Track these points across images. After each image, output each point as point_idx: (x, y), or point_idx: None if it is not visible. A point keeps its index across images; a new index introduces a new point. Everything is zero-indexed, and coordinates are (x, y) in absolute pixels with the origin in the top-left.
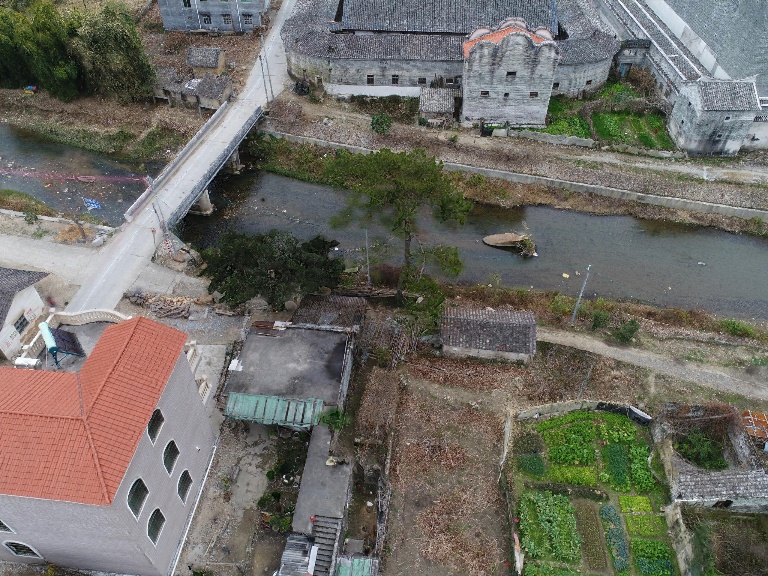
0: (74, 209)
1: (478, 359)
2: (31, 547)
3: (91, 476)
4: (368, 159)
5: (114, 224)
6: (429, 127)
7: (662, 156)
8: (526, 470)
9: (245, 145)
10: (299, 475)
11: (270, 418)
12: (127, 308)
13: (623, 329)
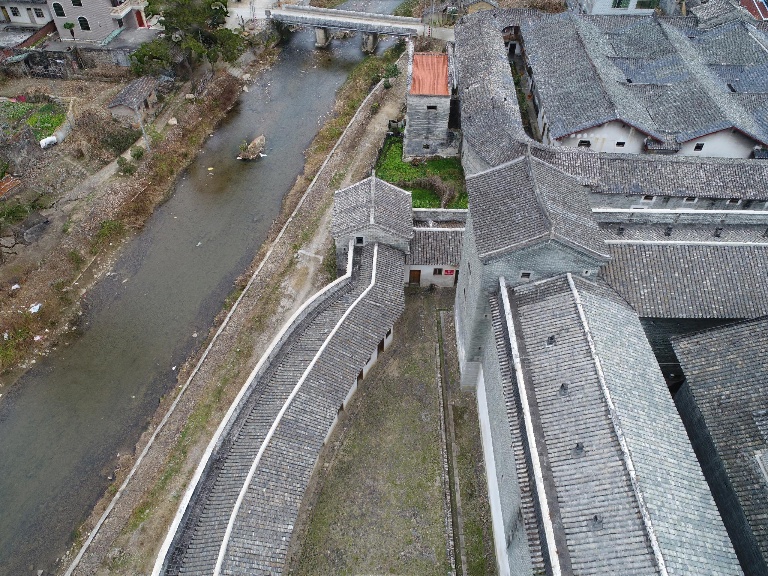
0: None
1: None
2: None
3: None
4: None
5: None
6: None
7: None
8: (44, 106)
9: (395, 47)
10: None
11: None
12: None
13: None
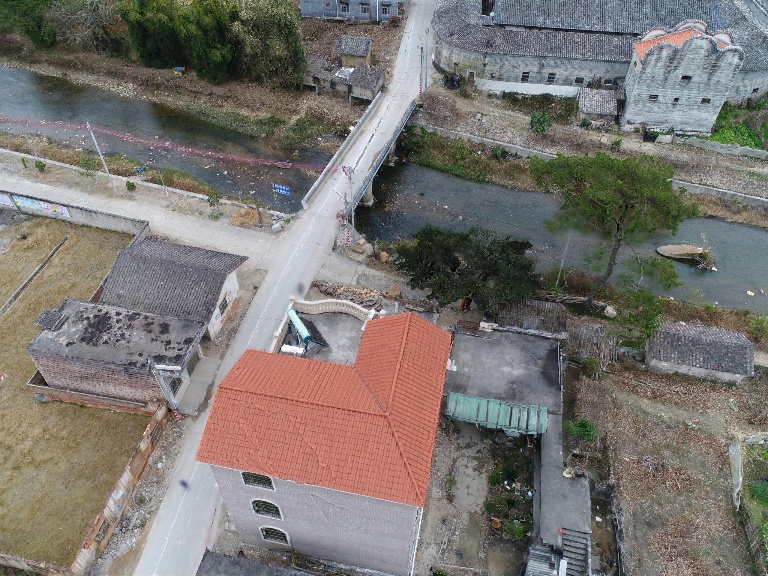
0: (236, 192)
1: (686, 376)
2: (287, 534)
3: (402, 475)
4: (590, 162)
5: (278, 210)
6: (587, 129)
7: None
8: (761, 499)
9: None
10: (519, 482)
11: (493, 422)
12: (317, 297)
13: None
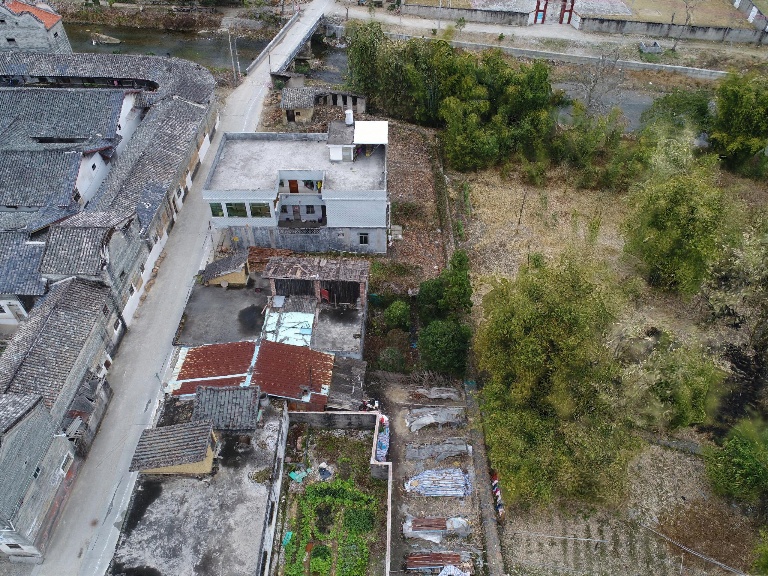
0: None
1: None
2: None
3: None
4: None
5: None
6: None
7: None
8: None
9: None
10: None
11: None
12: None
13: None
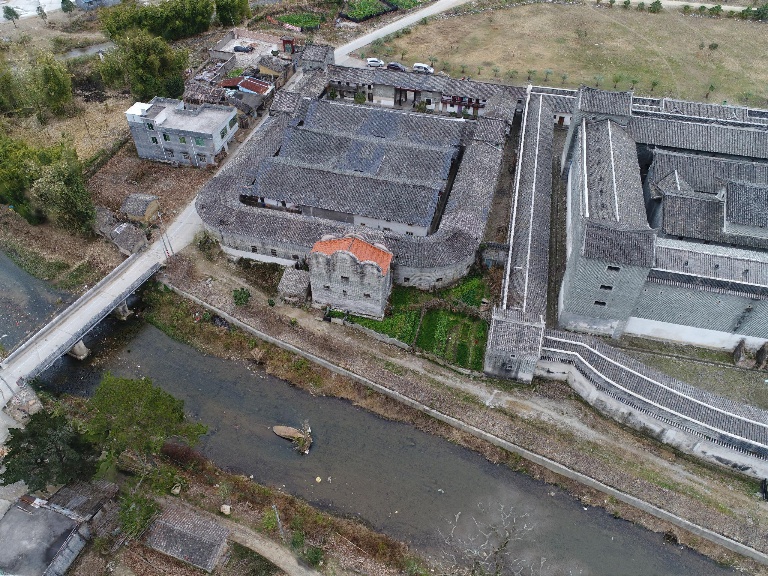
0: None
1: (177, 559)
2: None
3: None
4: None
5: None
6: (286, 303)
7: (462, 372)
8: None
9: (142, 292)
10: None
11: None
12: None
13: (309, 555)
